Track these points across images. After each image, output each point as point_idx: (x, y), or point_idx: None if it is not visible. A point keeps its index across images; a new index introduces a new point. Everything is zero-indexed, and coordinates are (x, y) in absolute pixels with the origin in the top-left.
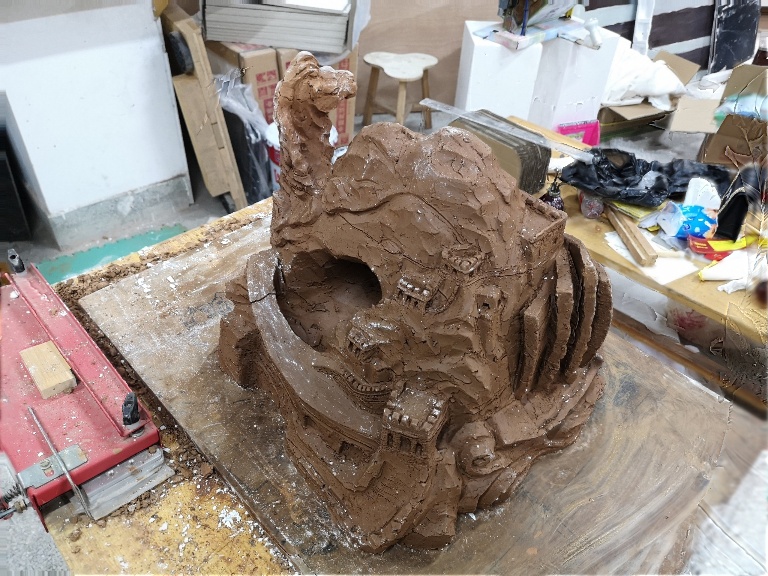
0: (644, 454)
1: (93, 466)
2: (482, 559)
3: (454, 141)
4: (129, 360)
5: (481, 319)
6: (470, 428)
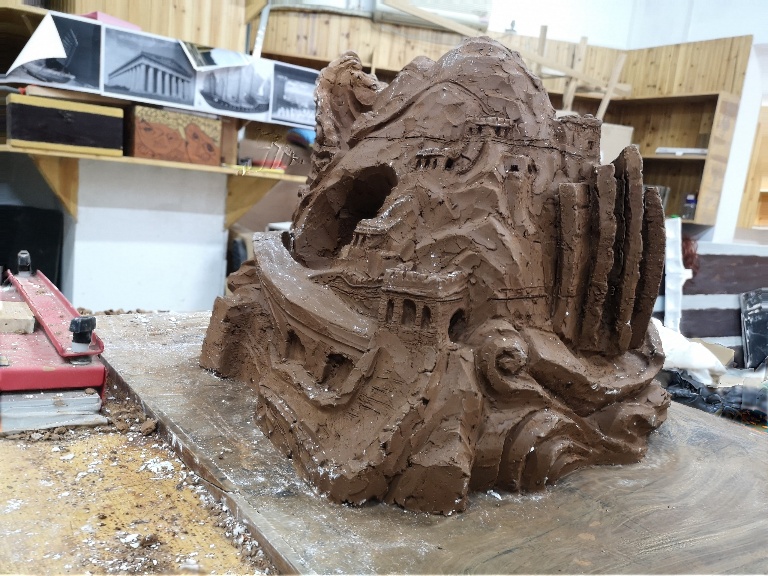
0: (740, 482)
1: (12, 372)
2: (510, 532)
3: (483, 40)
4: None
5: (509, 180)
6: (494, 323)
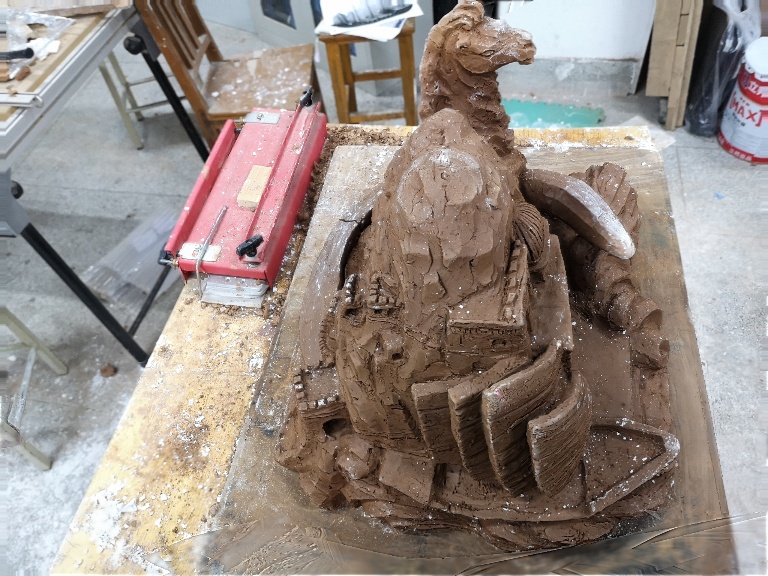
0: None
1: (216, 267)
2: None
3: (433, 170)
4: (316, 211)
5: None
6: (355, 440)
